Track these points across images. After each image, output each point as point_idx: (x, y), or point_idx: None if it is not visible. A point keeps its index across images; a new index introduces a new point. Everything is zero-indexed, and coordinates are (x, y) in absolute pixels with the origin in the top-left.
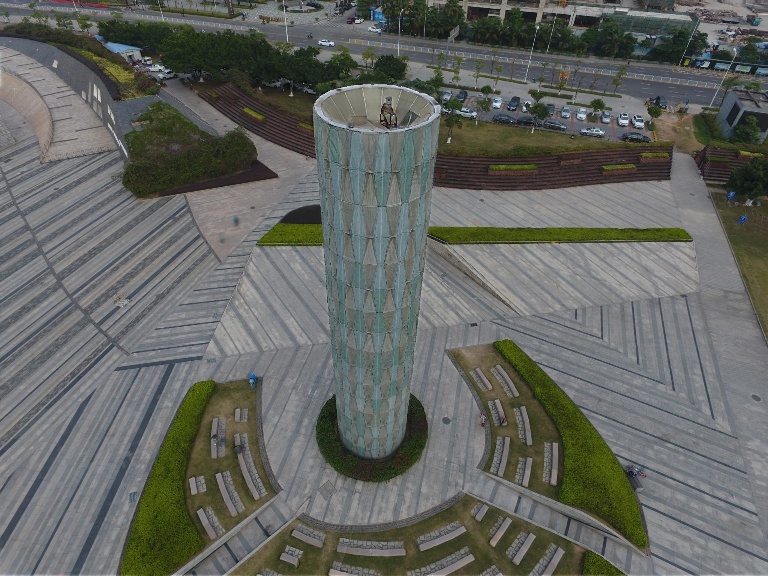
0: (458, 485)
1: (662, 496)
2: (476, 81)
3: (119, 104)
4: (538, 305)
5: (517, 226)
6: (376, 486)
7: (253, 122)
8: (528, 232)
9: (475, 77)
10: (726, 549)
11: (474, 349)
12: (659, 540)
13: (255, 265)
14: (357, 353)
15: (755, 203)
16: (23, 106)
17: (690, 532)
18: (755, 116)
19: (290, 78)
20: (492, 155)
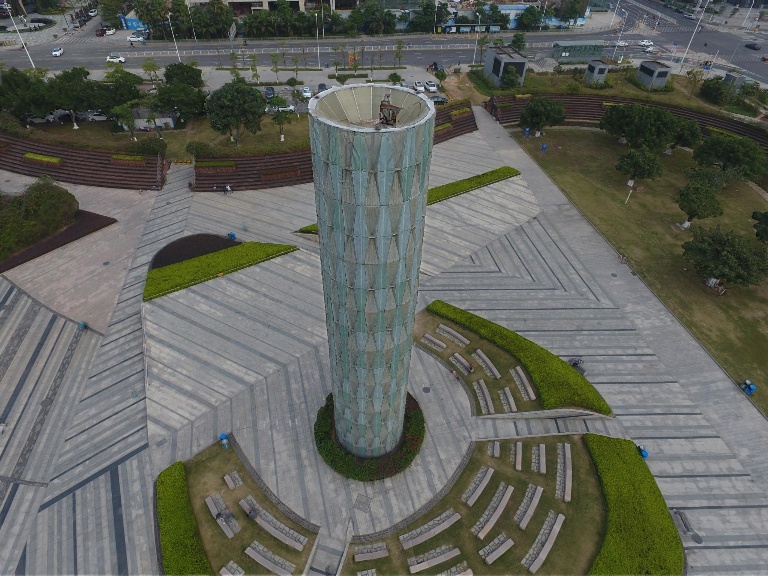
0: (466, 438)
1: (600, 371)
2: (276, 75)
3: None
4: (441, 262)
5: None
6: (403, 475)
7: (46, 168)
8: None
9: (275, 71)
10: (652, 387)
11: None
12: (615, 403)
13: (154, 323)
14: (376, 355)
15: (541, 133)
16: None
17: (628, 387)
18: (513, 65)
19: (69, 108)
20: None
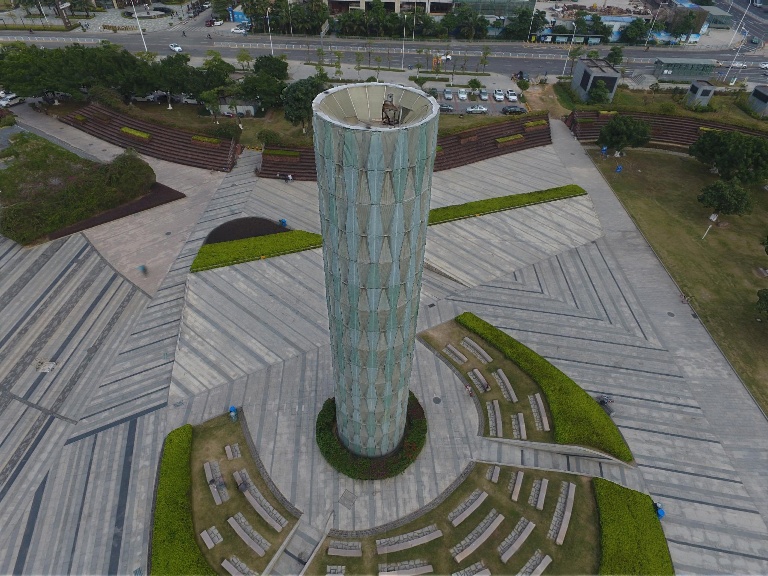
0: (467, 456)
1: (630, 414)
2: (358, 73)
3: None
4: (481, 275)
5: (440, 206)
6: (393, 480)
7: (137, 142)
8: (453, 210)
9: (357, 69)
10: (688, 442)
11: (439, 328)
12: (639, 451)
13: (195, 293)
14: (369, 354)
15: (621, 154)
16: None
17: (659, 437)
18: (603, 80)
19: (166, 89)
20: None
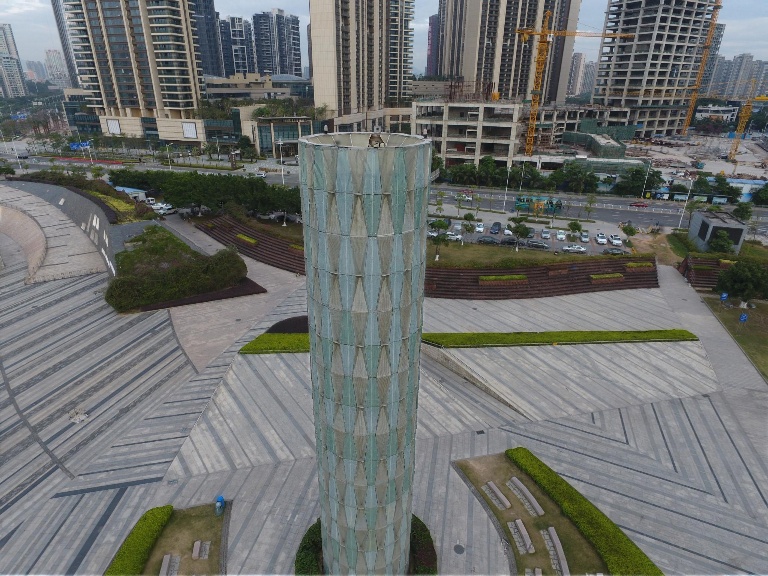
0: None
1: None
2: (458, 211)
3: (115, 227)
4: (549, 409)
5: (514, 331)
6: None
7: (246, 246)
8: (527, 335)
9: (457, 207)
10: None
11: (484, 460)
12: None
13: (235, 373)
14: (346, 438)
15: (750, 305)
16: (21, 237)
17: None
18: (725, 230)
19: (284, 209)
20: (481, 267)
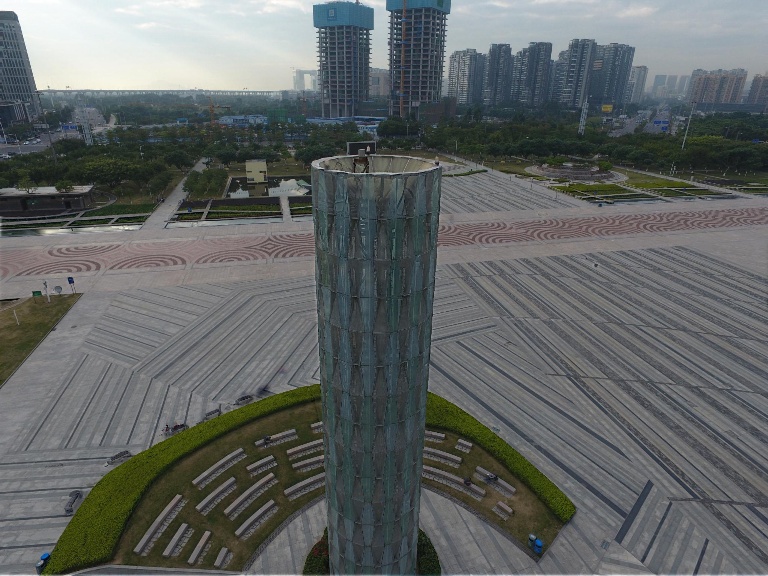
0: (252, 575)
1: None
2: None
3: None
4: None
5: None
6: None
7: None
8: None
9: None
10: None
11: None
12: None
13: None
14: None
15: None
16: None
17: None
18: None
19: None
20: None
